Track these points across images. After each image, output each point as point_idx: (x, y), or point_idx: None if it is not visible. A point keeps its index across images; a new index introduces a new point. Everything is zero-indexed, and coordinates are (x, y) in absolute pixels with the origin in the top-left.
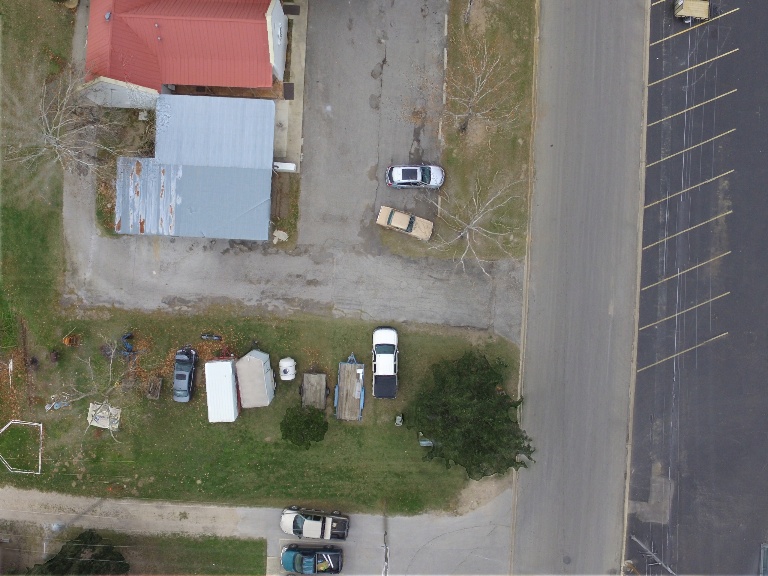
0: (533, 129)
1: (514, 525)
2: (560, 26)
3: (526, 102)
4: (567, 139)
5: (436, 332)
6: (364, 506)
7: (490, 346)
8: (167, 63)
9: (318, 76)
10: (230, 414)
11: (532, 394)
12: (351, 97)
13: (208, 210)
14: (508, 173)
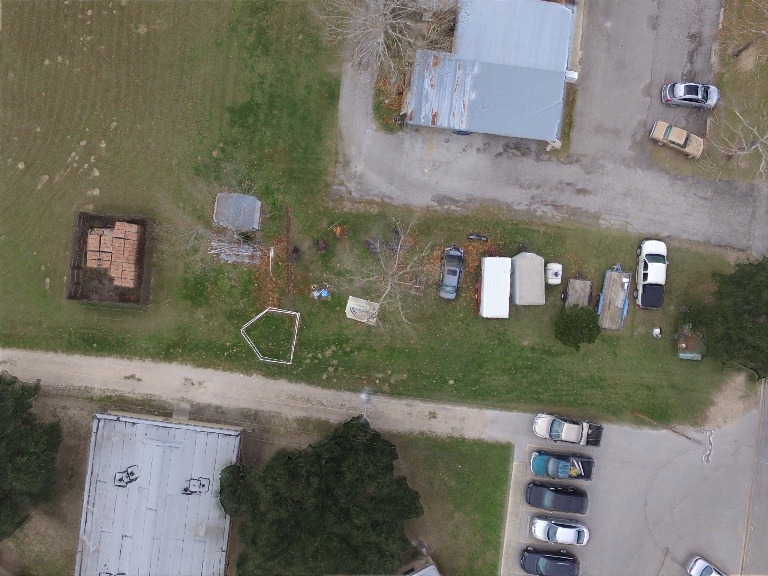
0: None
1: (758, 446)
2: None
3: None
4: None
5: (697, 249)
6: (614, 417)
7: None
8: None
9: None
10: (505, 310)
11: None
12: (629, 16)
13: (501, 108)
14: None
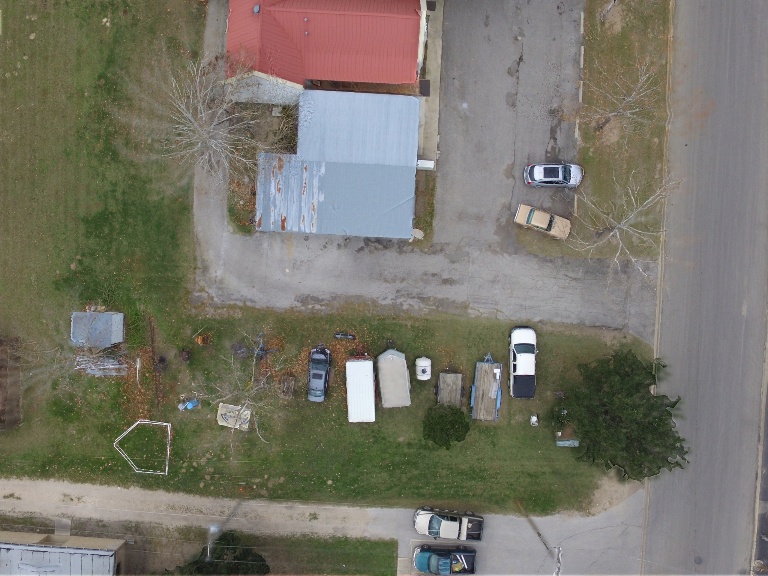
0: (668, 128)
1: (646, 525)
2: (694, 25)
3: (660, 101)
4: (701, 139)
5: (571, 332)
6: (496, 506)
7: (624, 346)
8: (310, 58)
9: (454, 73)
10: (370, 414)
11: (665, 394)
12: (487, 94)
13: (351, 207)
14: (644, 172)
